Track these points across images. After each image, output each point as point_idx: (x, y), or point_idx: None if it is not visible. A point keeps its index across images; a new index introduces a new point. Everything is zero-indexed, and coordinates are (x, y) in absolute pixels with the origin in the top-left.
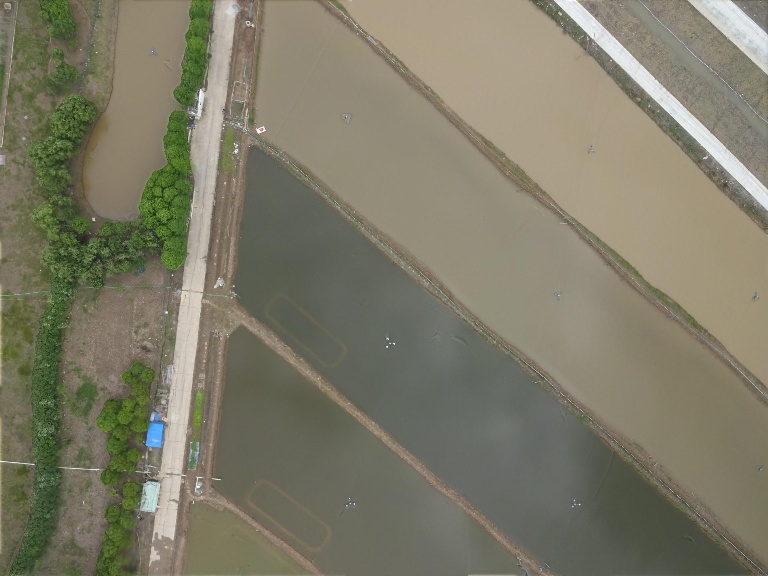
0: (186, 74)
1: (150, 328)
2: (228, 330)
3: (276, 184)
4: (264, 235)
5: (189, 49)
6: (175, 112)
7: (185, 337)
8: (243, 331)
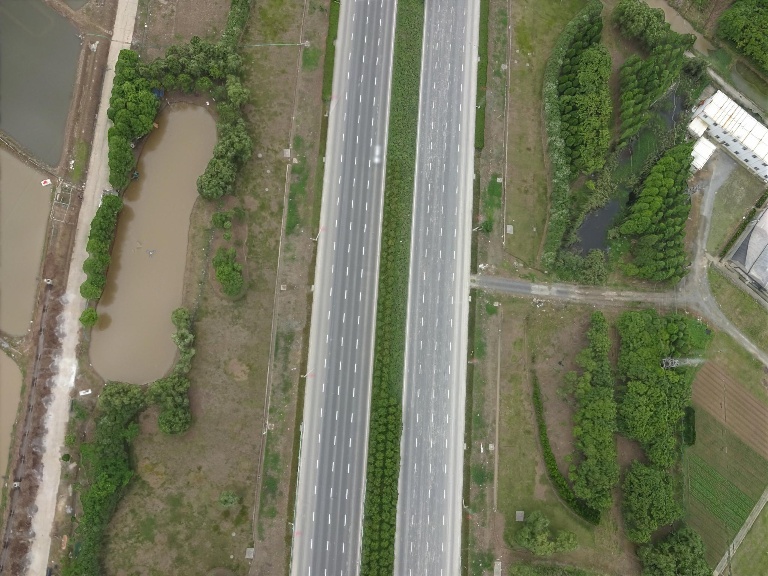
0: (101, 213)
1: (161, 14)
2: (88, 7)
3: (35, 134)
4: (48, 85)
5: (100, 240)
6: (114, 178)
7: (130, 5)
8: (74, 6)
